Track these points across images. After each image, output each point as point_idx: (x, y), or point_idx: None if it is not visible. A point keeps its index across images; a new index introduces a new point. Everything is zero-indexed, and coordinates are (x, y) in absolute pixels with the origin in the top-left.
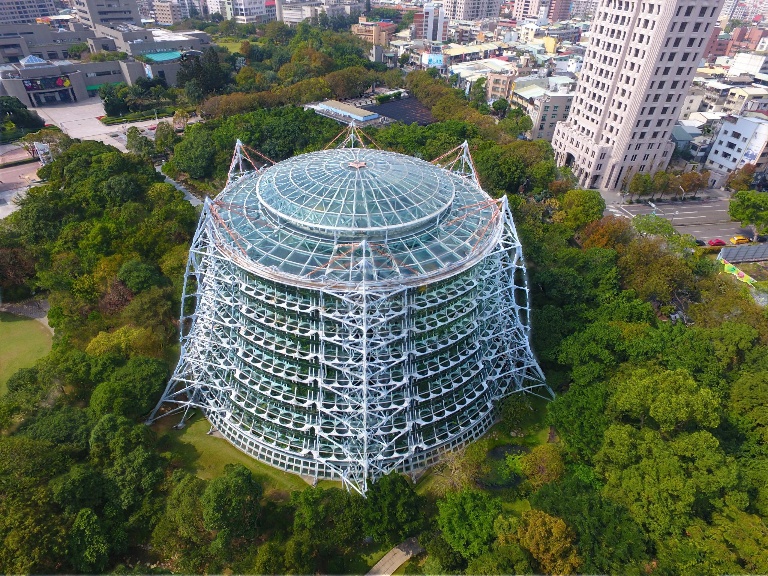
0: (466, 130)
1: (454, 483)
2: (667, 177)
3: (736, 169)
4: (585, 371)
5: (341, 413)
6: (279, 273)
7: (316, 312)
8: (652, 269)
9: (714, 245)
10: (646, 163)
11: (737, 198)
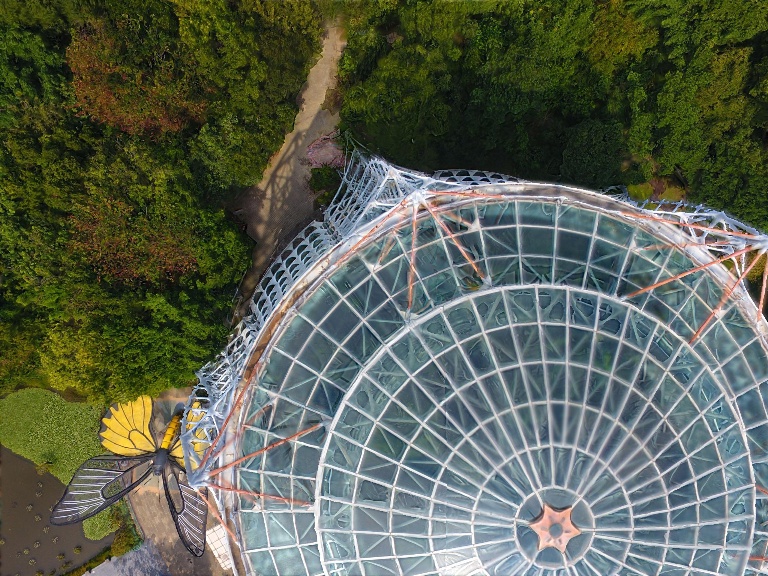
0: None
1: None
2: None
3: None
4: None
5: None
6: None
7: None
8: None
9: None
10: None
11: None
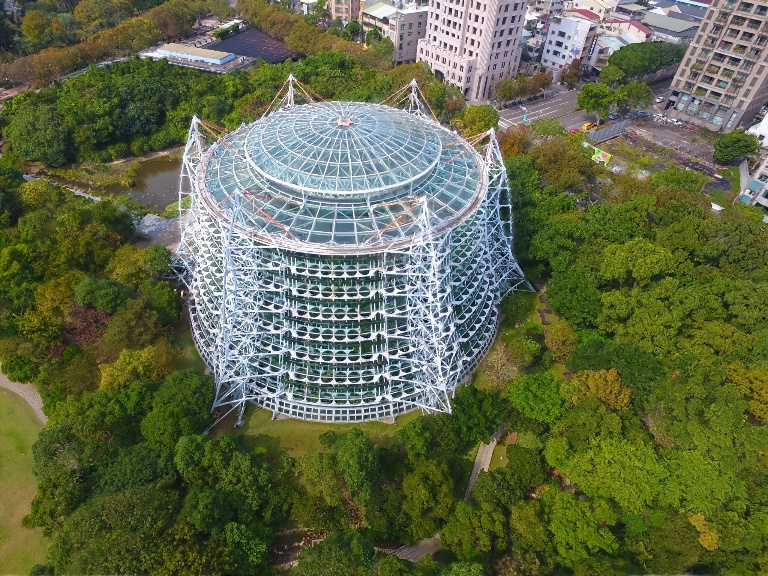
0: (344, 61)
1: (510, 376)
2: (525, 81)
3: (566, 64)
4: (561, 260)
5: (404, 355)
6: (337, 246)
7: (376, 273)
8: (561, 165)
9: None
10: (504, 70)
11: (582, 91)
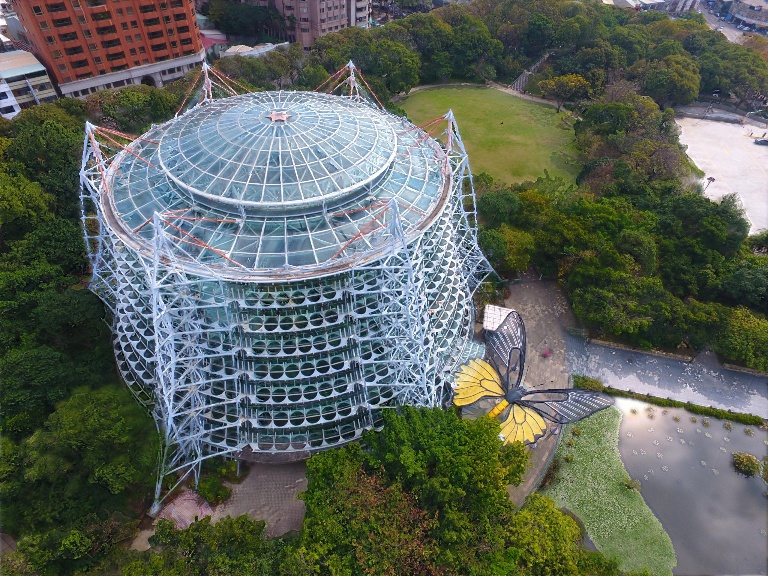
0: None
1: None
2: None
3: None
4: None
5: None
6: None
7: None
8: None
9: None
10: None
11: None
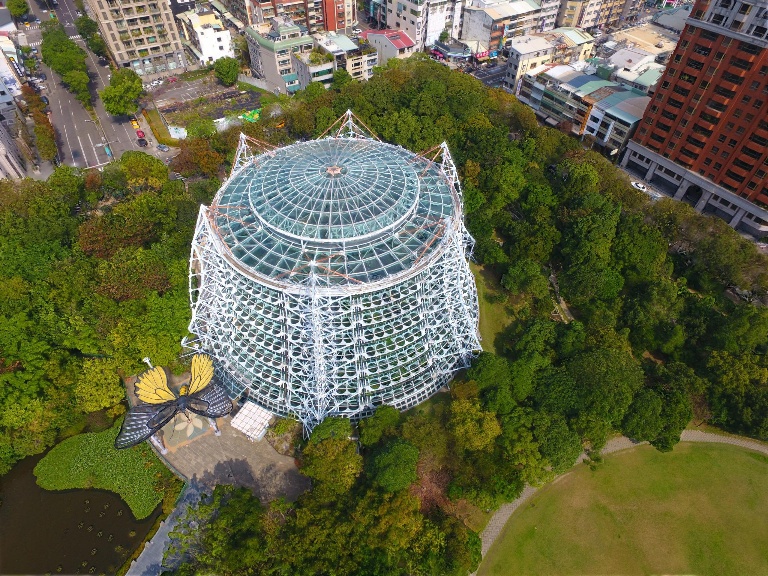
0: None
1: None
2: None
3: (14, 98)
4: None
5: None
6: None
7: None
8: None
9: (144, 135)
10: (5, 136)
11: (106, 101)
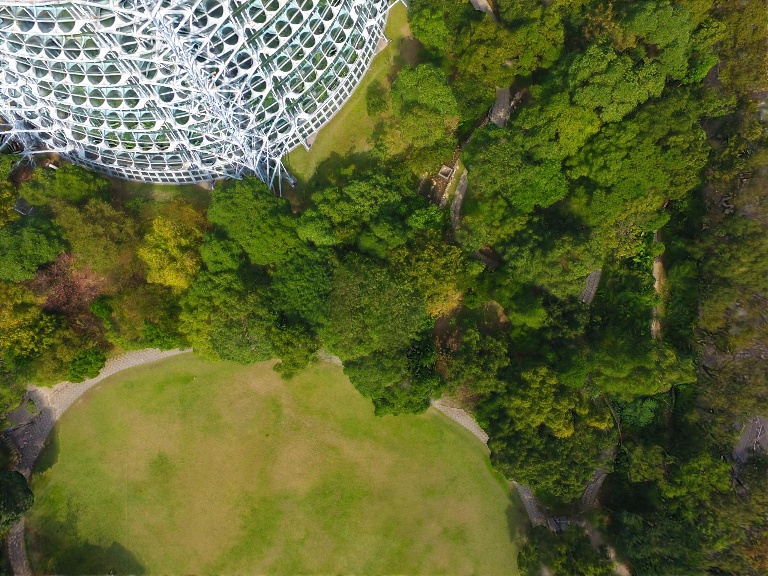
0: None
1: None
2: None
3: None
4: None
5: None
6: None
7: None
8: None
9: None
10: None
11: None
